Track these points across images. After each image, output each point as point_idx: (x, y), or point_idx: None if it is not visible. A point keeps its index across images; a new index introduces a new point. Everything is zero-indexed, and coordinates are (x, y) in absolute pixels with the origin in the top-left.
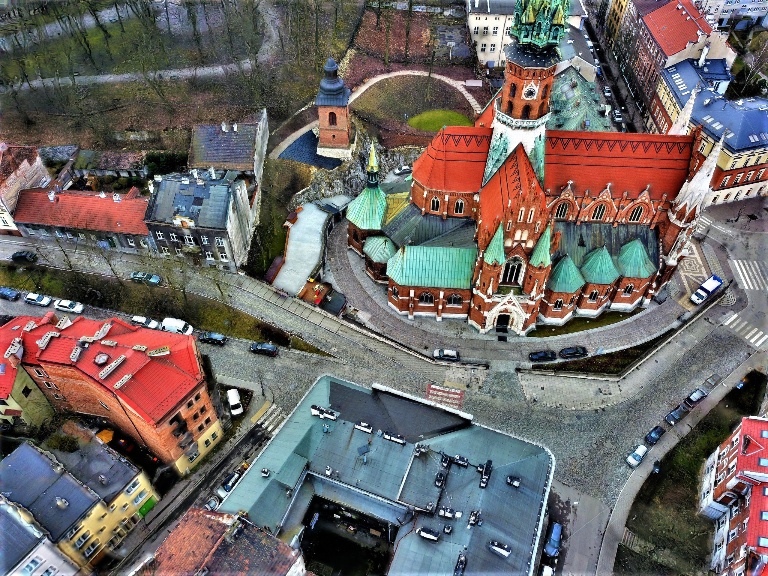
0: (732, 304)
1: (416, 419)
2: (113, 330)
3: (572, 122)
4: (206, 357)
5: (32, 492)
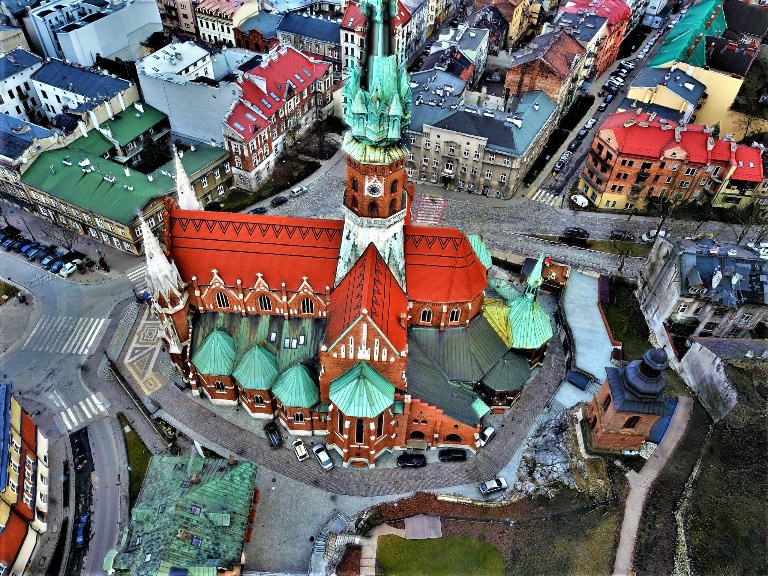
0: None
1: (458, 124)
2: None
3: (209, 498)
4: (607, 166)
5: (654, 109)
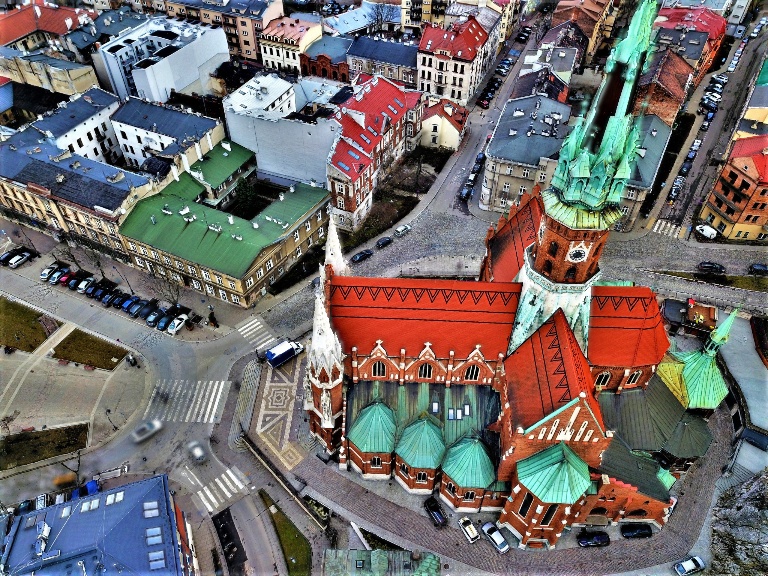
0: (254, 360)
1: None
2: None
3: None
4: (743, 196)
5: None
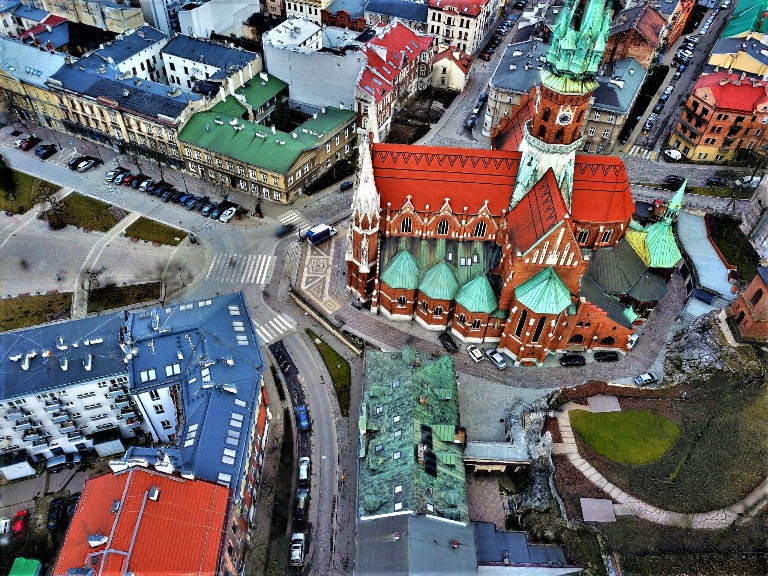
0: (295, 241)
1: None
2: (765, 97)
3: (431, 377)
4: (703, 120)
5: (735, 73)
